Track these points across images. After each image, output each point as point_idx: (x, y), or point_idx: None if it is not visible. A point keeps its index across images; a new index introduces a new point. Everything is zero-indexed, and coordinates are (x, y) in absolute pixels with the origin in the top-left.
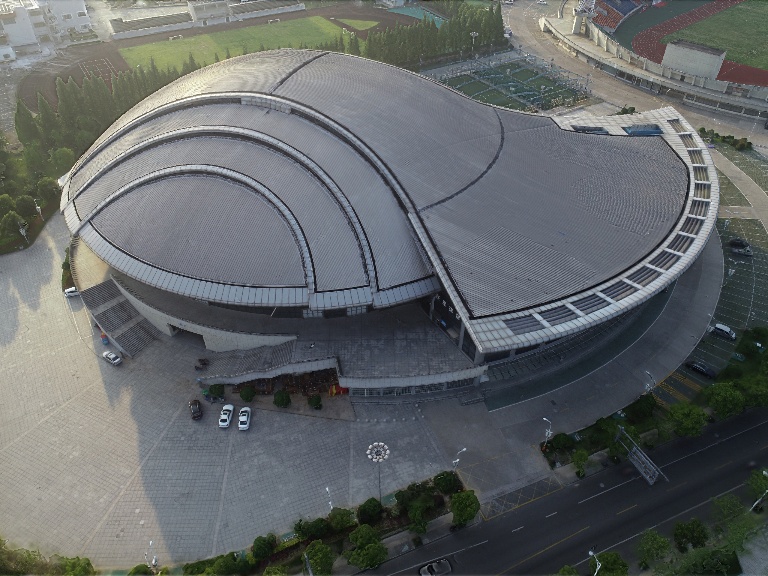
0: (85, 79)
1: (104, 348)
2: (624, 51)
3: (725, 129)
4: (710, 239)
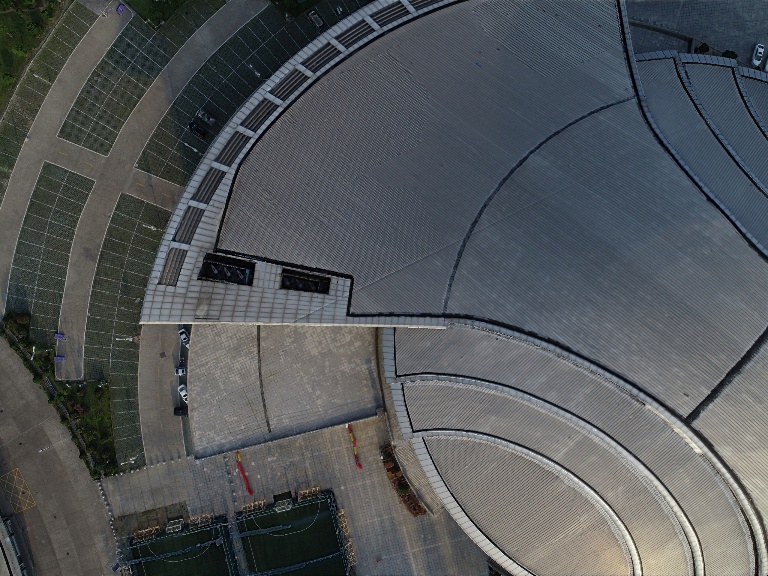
0: None
1: None
2: None
3: None
4: None
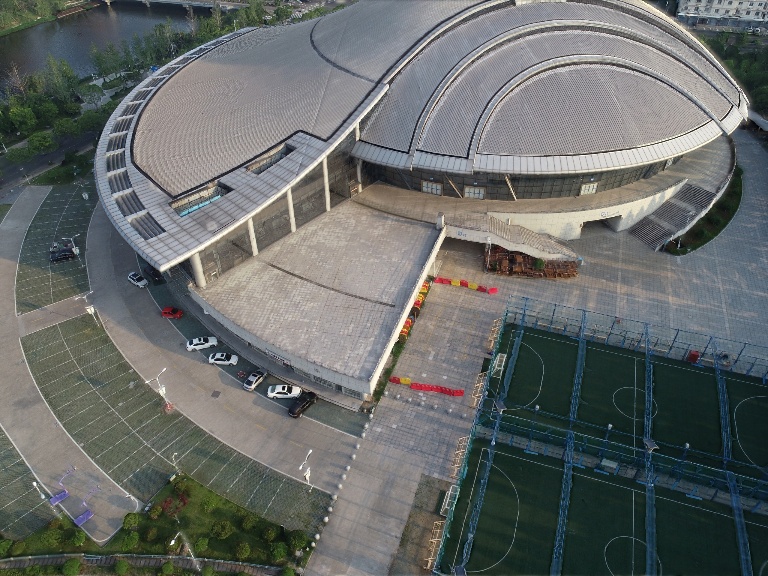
0: None
1: None
2: None
3: None
4: (99, 255)
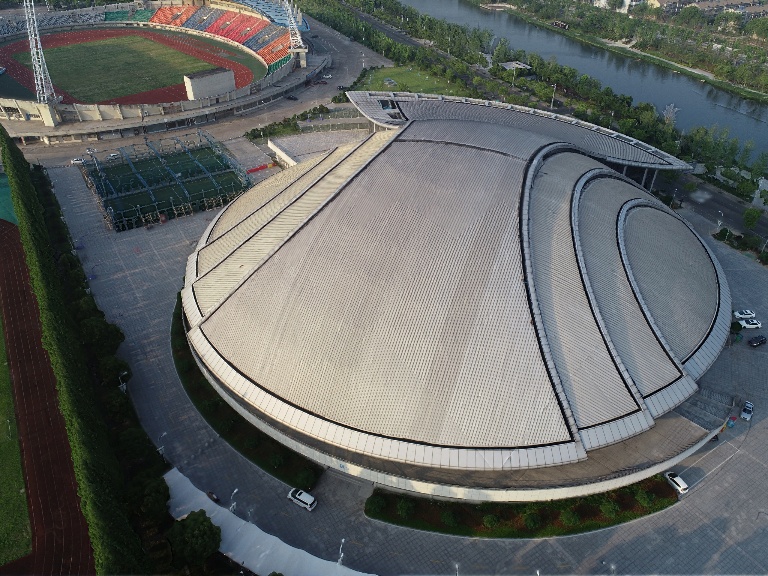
0: (103, 574)
1: (737, 425)
2: (152, 107)
3: (292, 111)
4: None
